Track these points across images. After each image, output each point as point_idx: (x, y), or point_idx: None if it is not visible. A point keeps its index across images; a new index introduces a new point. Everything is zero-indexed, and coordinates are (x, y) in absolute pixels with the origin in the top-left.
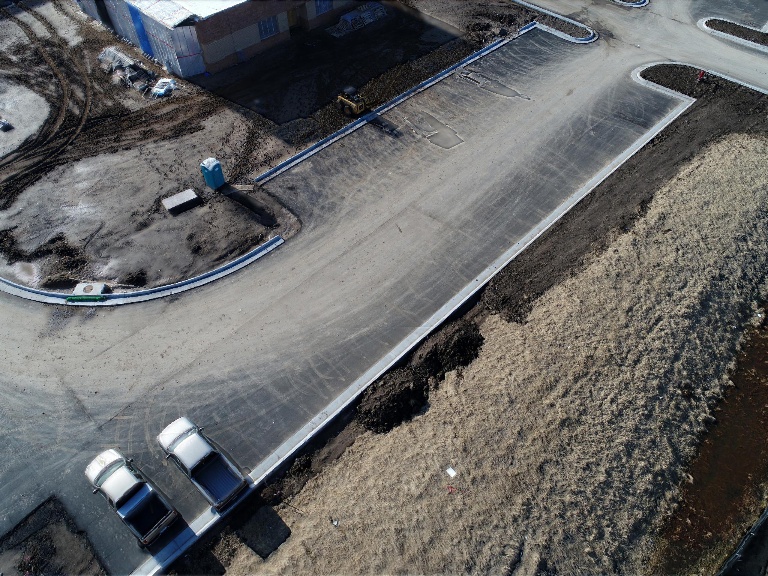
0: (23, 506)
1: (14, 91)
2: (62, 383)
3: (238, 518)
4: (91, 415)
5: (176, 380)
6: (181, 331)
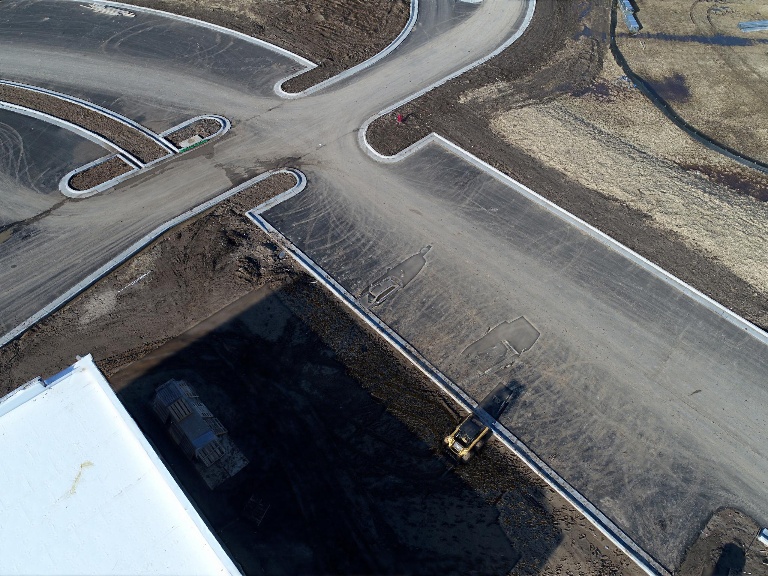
0: None
1: None
2: None
3: None
4: None
5: None
6: None
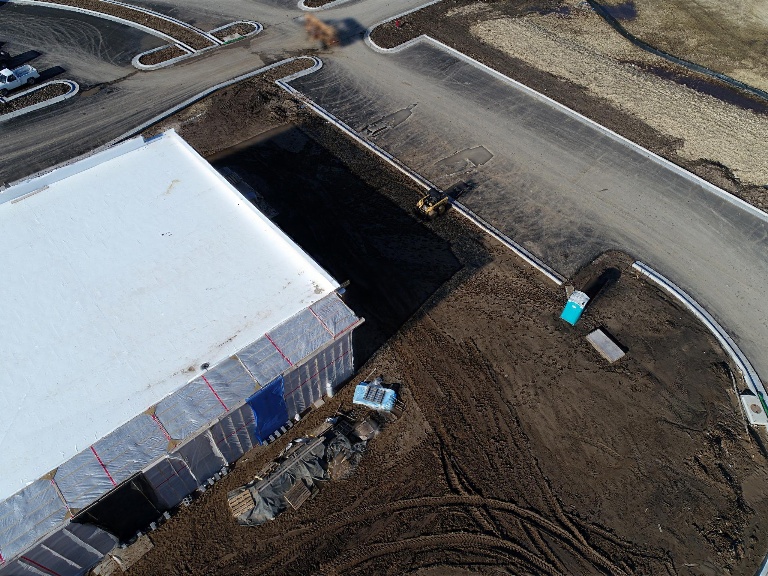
0: None
1: None
2: None
3: None
4: None
5: None
6: (766, 324)
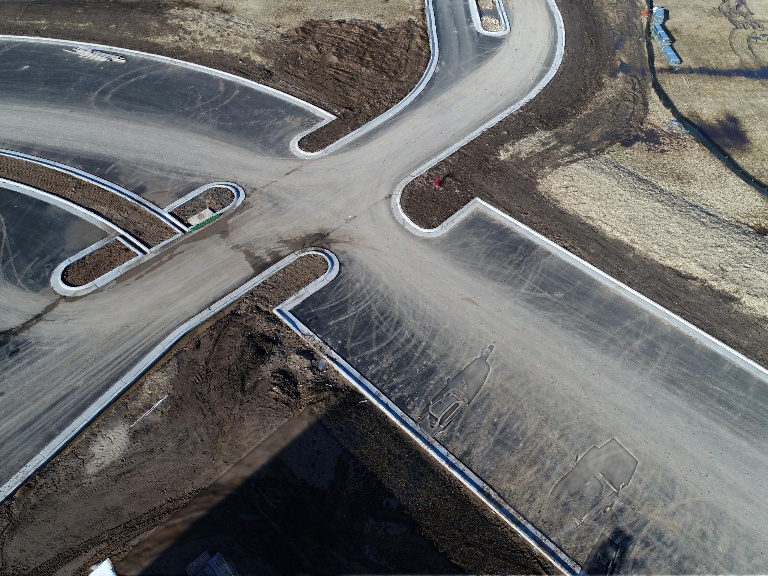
0: None
1: None
2: None
3: None
4: None
5: None
6: None
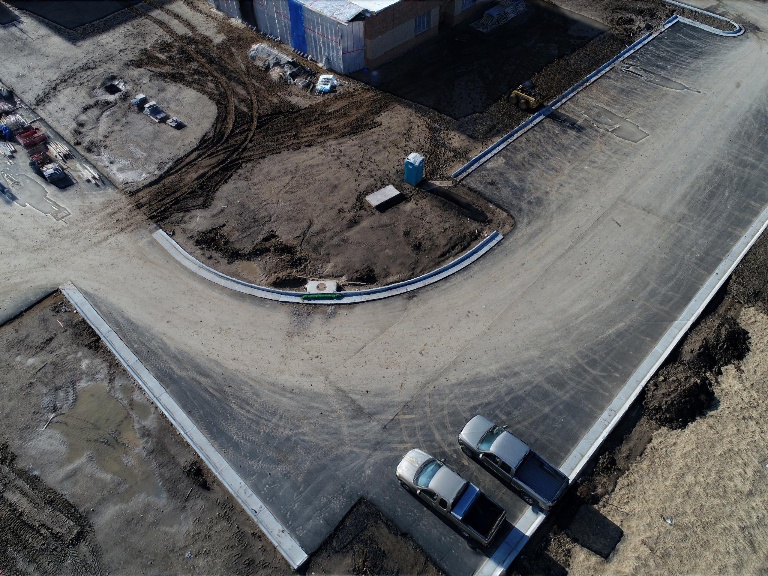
0: (335, 508)
1: (173, 89)
2: (329, 382)
3: (563, 518)
4: (371, 415)
5: (445, 378)
6: (431, 328)
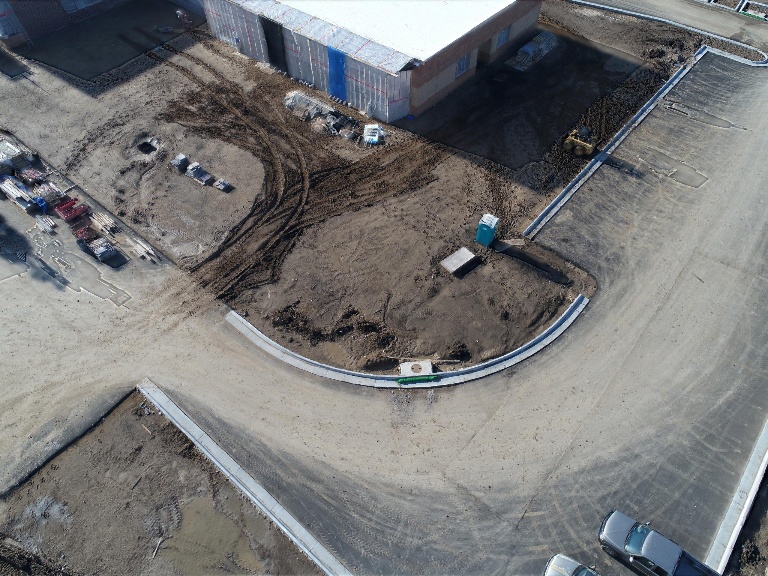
0: None
1: (212, 146)
2: (448, 479)
3: None
4: (499, 514)
5: (566, 466)
6: (539, 409)
